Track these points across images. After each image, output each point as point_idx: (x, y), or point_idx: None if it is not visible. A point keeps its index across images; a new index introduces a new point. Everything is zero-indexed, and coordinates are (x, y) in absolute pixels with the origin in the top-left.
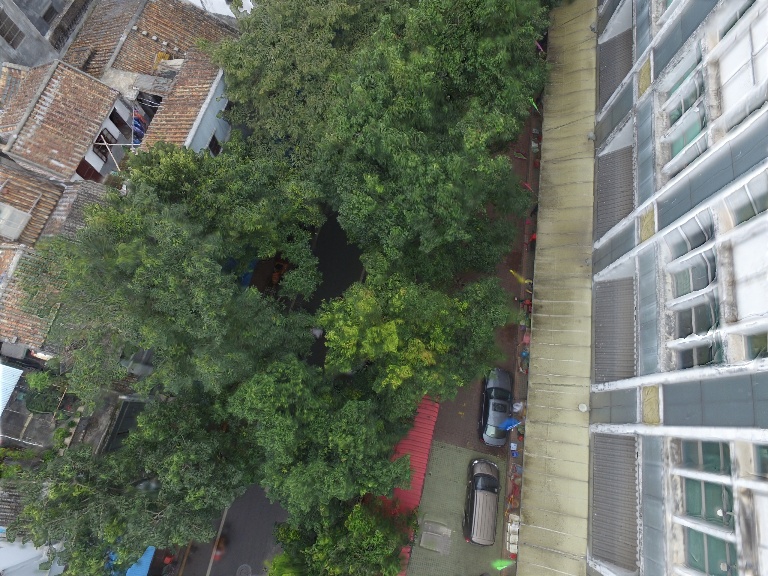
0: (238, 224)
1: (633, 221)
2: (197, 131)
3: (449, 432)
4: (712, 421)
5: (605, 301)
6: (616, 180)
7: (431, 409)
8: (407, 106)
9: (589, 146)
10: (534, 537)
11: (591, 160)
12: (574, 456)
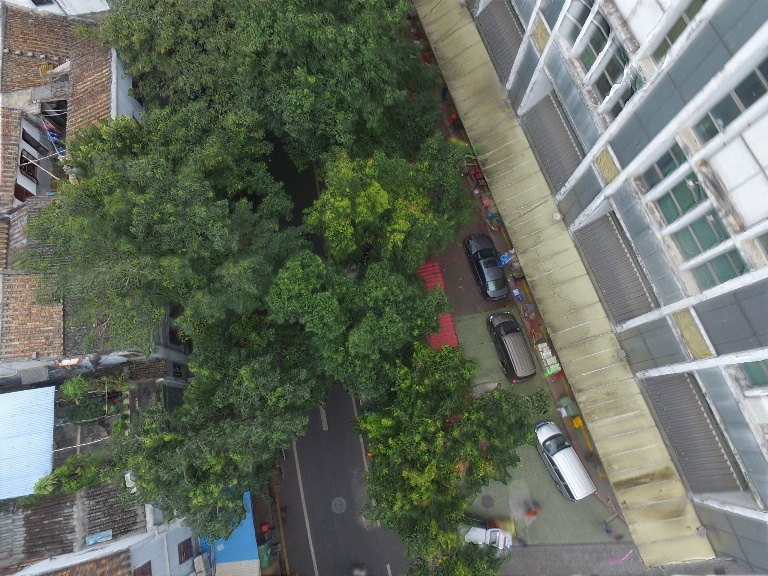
0: (199, 164)
1: (529, 41)
2: (117, 111)
3: (458, 307)
4: (656, 131)
5: (535, 126)
6: (500, 27)
7: (436, 280)
8: None
9: (465, 14)
10: (566, 339)
11: (472, 24)
12: (567, 260)
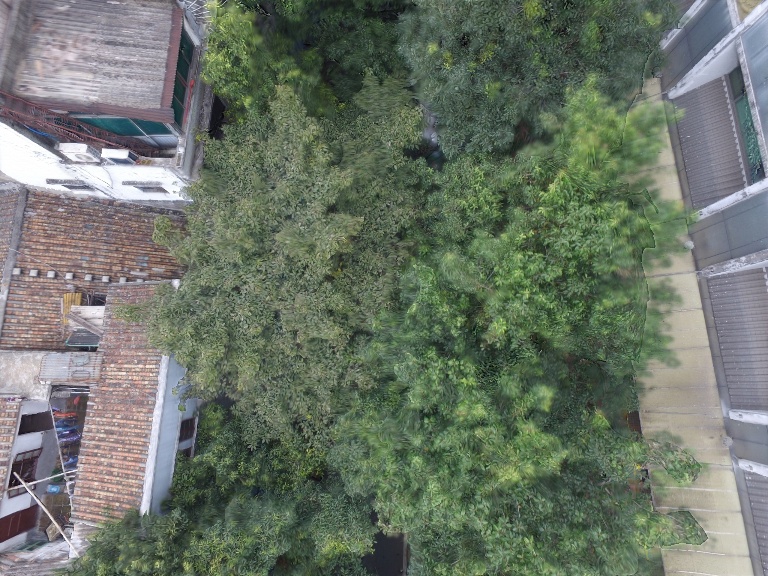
0: None
1: None
2: (157, 455)
3: None
4: None
5: (766, 503)
6: (745, 319)
7: None
8: (515, 476)
9: (685, 255)
10: None
11: (692, 276)
12: None
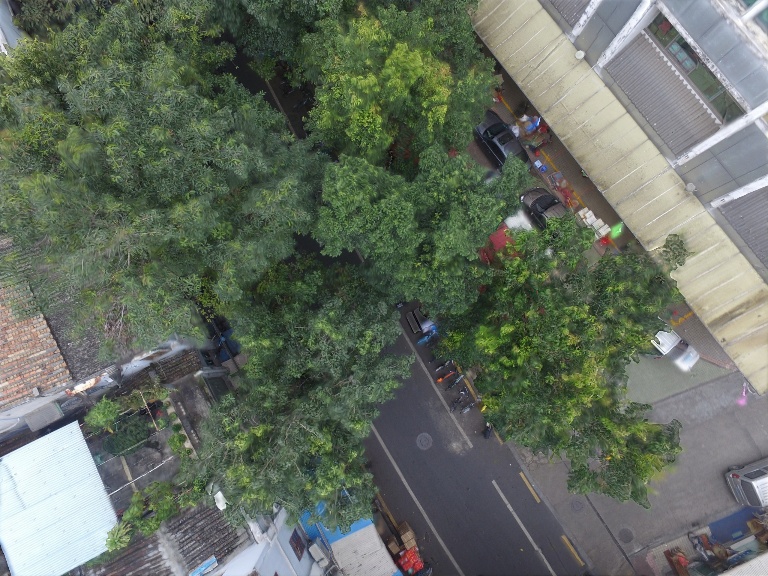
0: None
1: None
2: None
3: None
4: None
5: None
6: None
7: None
8: None
9: None
10: (620, 193)
11: None
12: (601, 104)
